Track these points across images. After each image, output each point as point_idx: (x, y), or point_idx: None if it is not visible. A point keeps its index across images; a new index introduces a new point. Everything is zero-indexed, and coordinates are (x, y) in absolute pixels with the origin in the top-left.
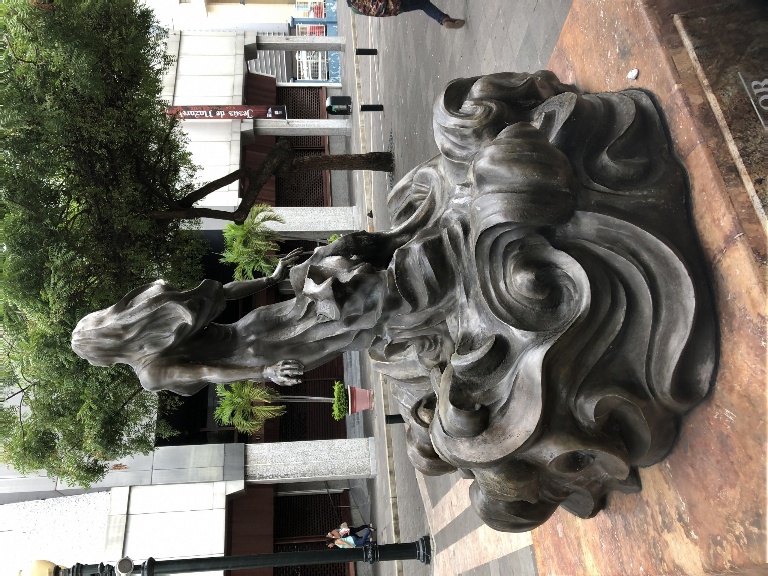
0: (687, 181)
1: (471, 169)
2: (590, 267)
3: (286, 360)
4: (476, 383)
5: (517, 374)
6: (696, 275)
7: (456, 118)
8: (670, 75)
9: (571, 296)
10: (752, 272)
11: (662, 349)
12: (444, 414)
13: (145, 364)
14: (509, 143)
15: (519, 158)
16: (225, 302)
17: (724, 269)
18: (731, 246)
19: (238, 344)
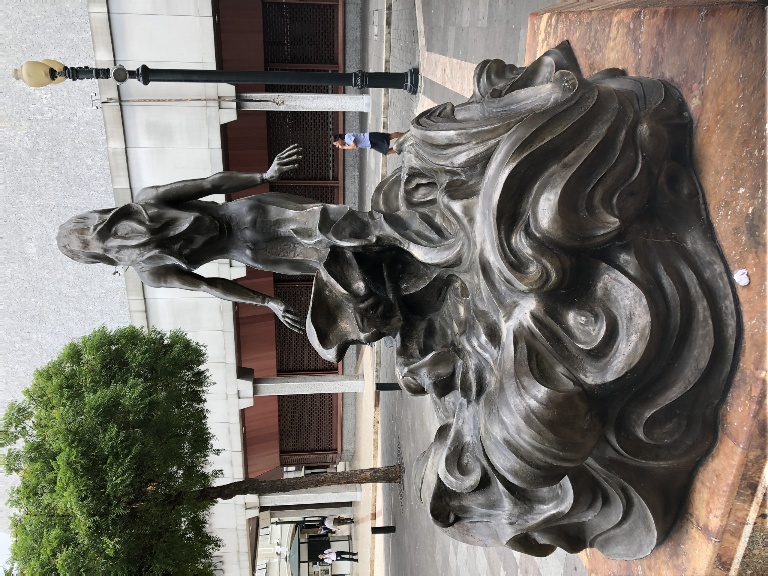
0: (712, 448)
1: (504, 325)
2: (580, 488)
3: (287, 307)
4: (455, 492)
5: (489, 521)
6: (669, 511)
7: (504, 265)
8: (767, 356)
9: (556, 484)
10: (705, 568)
11: (611, 542)
12: (424, 503)
13: (142, 270)
14: (540, 434)
15: (544, 450)
16: (218, 229)
17: (691, 533)
18: (705, 537)
19: (235, 245)
